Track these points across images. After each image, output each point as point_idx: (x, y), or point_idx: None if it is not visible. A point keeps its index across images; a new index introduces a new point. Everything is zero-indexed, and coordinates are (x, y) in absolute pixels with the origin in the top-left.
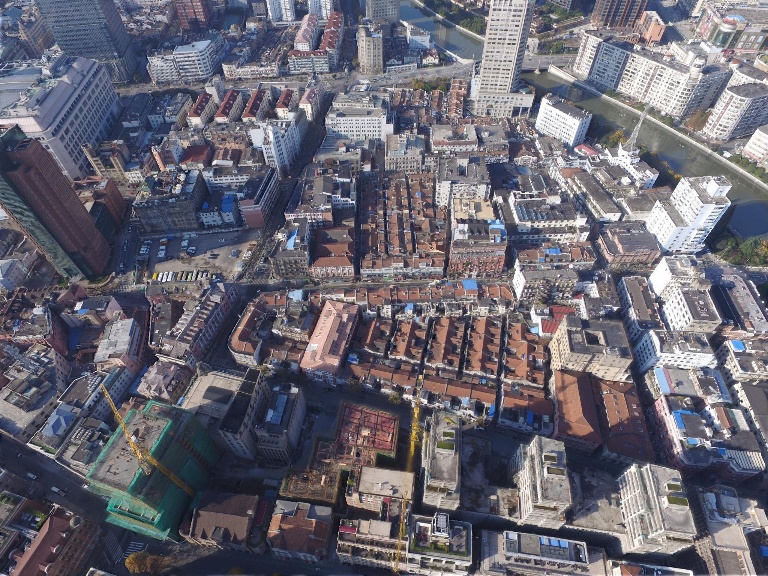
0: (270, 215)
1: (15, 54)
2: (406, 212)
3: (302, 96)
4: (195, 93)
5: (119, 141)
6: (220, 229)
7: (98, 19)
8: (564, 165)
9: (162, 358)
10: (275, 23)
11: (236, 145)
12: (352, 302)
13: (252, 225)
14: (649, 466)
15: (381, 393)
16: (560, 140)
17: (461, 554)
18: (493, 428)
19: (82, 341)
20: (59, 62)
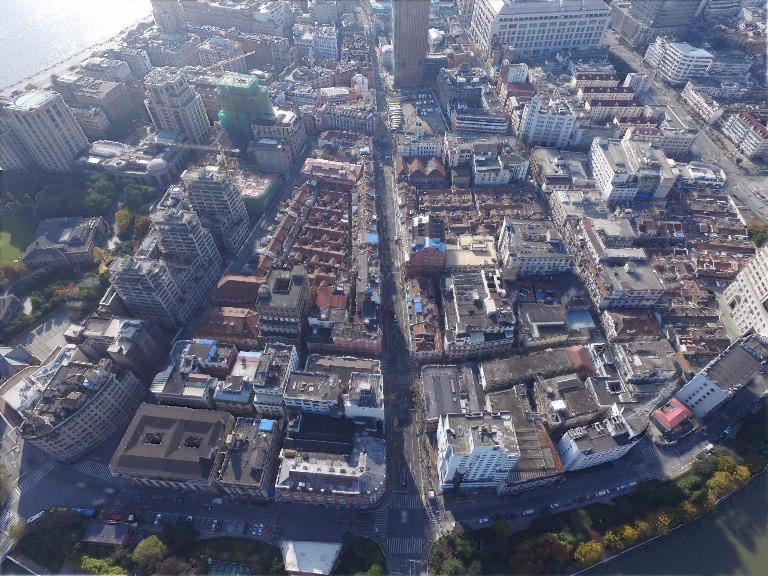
0: None
1: None
2: None
3: None
4: None
5: (512, 48)
6: None
7: None
8: None
9: None
10: None
11: None
12: None
13: None
14: (155, 259)
15: None
16: (674, 369)
17: (162, 203)
18: None
19: None
20: None
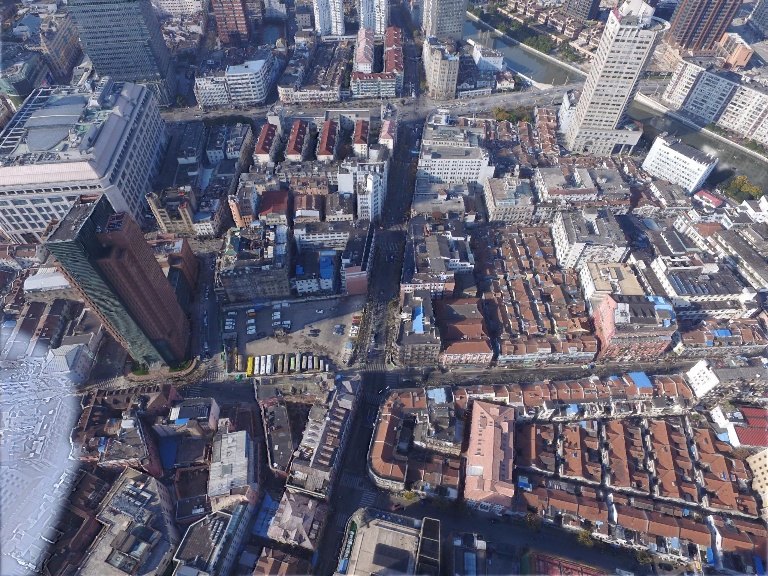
0: (370, 278)
1: (38, 71)
2: (530, 276)
3: (381, 129)
4: (251, 121)
5: (186, 188)
6: (315, 297)
7: (141, 35)
8: (698, 219)
9: (293, 489)
10: (324, 37)
11: (318, 190)
12: (502, 401)
13: (352, 292)
14: None
15: (563, 528)
16: (680, 186)
17: None
18: (706, 574)
19: (182, 459)
20: (106, 90)
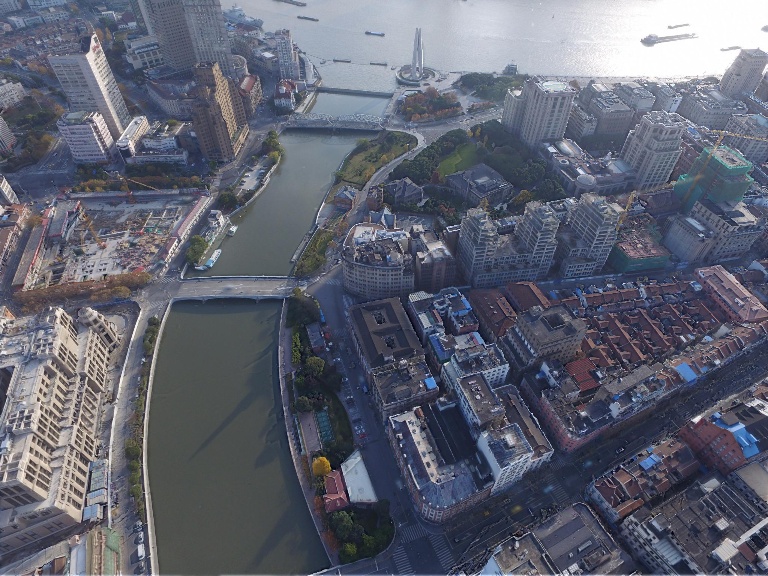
0: None
1: None
2: None
3: None
4: None
5: None
6: None
7: None
8: None
9: None
10: None
11: None
12: None
13: None
14: None
15: None
16: None
17: (553, 203)
18: None
19: None
20: None
